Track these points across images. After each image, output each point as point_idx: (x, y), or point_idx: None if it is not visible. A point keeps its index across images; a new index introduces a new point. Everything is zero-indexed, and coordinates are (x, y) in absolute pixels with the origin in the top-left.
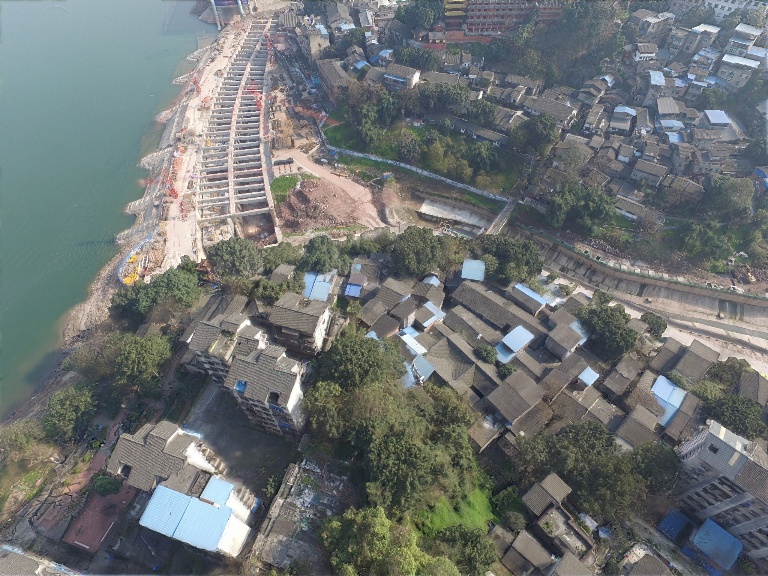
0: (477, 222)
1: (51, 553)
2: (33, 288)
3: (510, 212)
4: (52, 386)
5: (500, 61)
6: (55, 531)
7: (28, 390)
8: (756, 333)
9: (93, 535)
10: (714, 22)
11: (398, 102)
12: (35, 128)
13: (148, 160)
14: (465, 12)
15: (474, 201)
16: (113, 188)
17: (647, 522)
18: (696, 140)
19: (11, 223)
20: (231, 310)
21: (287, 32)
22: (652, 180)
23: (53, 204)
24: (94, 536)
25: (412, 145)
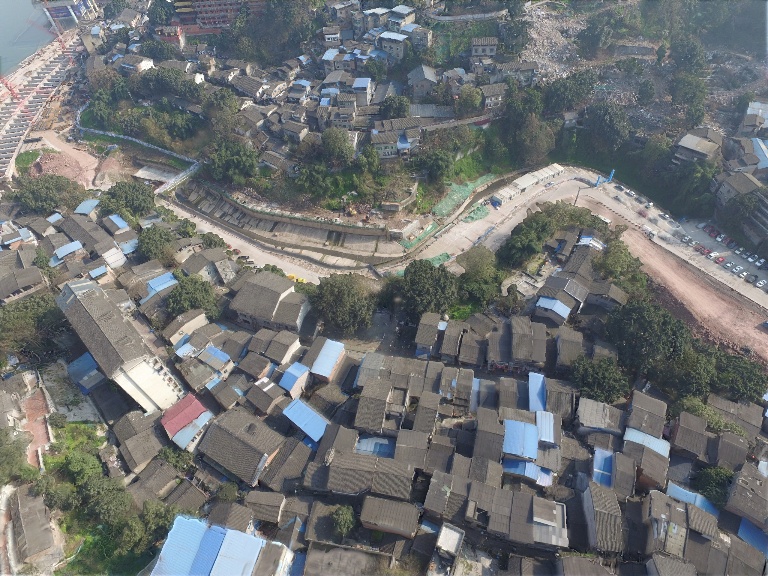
0: None
1: None
2: None
3: (194, 171)
4: None
5: (228, 49)
6: None
7: None
8: (348, 255)
9: None
10: (390, 6)
11: (126, 86)
12: None
13: None
14: (193, 8)
15: (174, 164)
16: None
17: (67, 363)
18: (340, 103)
19: None
20: None
21: None
22: (296, 137)
23: None
24: None
25: (130, 120)
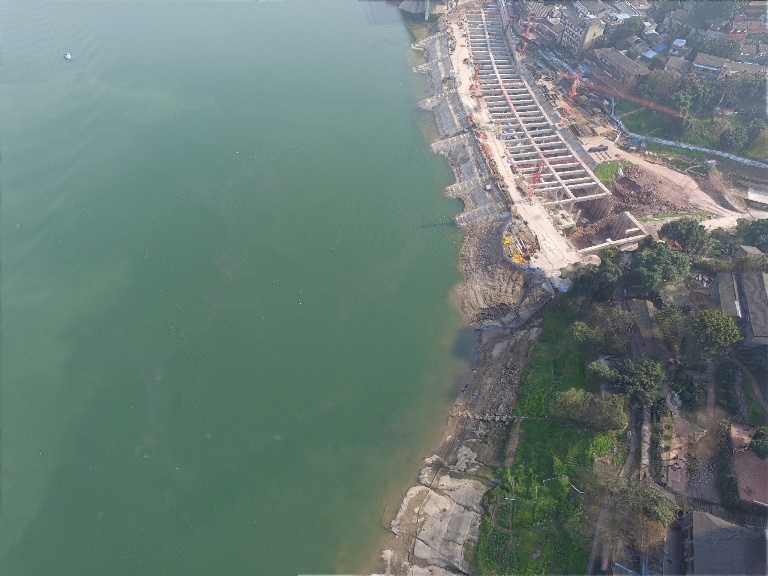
0: None
1: (715, 512)
2: (405, 267)
3: None
4: (486, 361)
5: None
6: (698, 492)
7: (464, 364)
8: None
9: (766, 495)
10: None
11: (715, 91)
12: (307, 114)
13: (443, 146)
14: None
15: None
16: (420, 173)
17: None
18: None
19: (342, 205)
20: (767, 287)
21: (535, 22)
22: None
23: (370, 187)
24: (767, 496)
25: (739, 133)
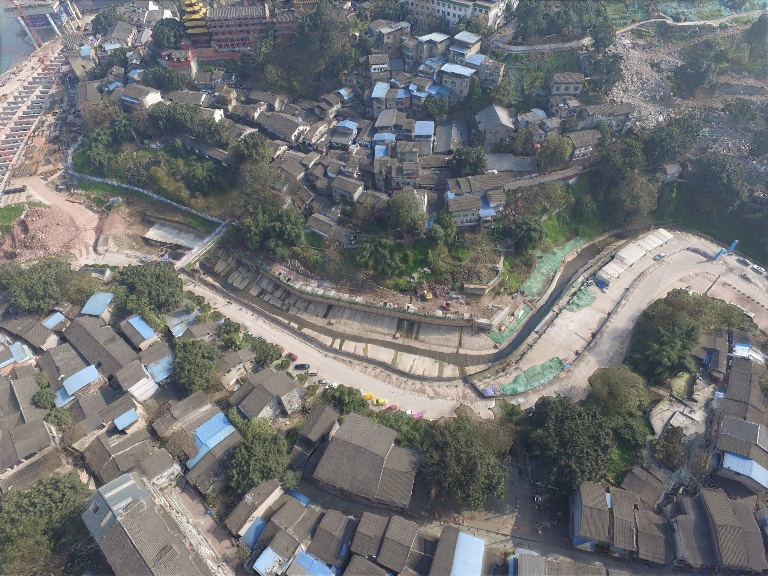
0: None
1: None
2: None
3: (221, 234)
4: None
5: (250, 77)
6: None
7: None
8: (426, 352)
9: None
10: (447, 30)
11: (130, 124)
12: None
13: None
14: (207, 29)
15: (194, 224)
16: None
17: None
18: (400, 153)
19: None
20: None
21: None
22: (349, 197)
23: None
24: None
25: (137, 168)
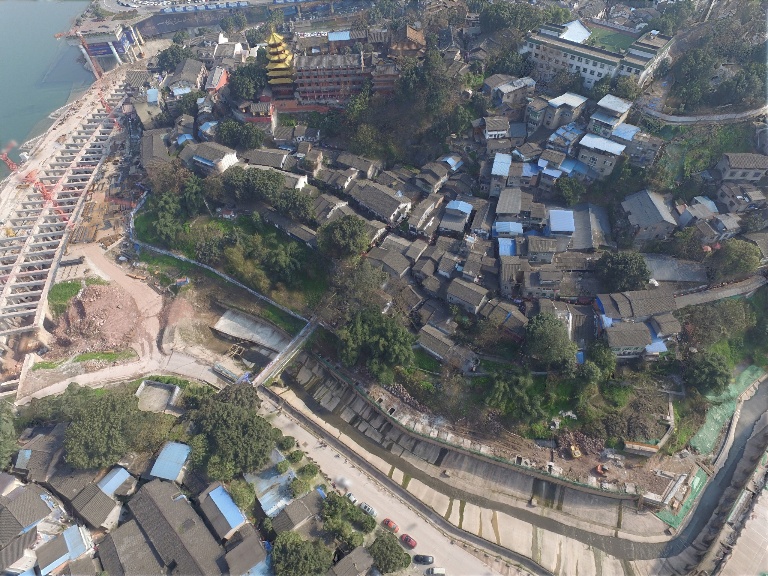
0: (276, 345)
1: None
2: None
3: (306, 338)
4: None
5: (337, 135)
6: None
7: None
8: (574, 532)
9: None
10: (582, 90)
11: (202, 191)
12: None
13: None
14: (292, 79)
15: (273, 318)
16: None
17: None
18: (532, 252)
19: None
20: None
21: None
22: (469, 307)
23: None
24: None
25: (209, 246)
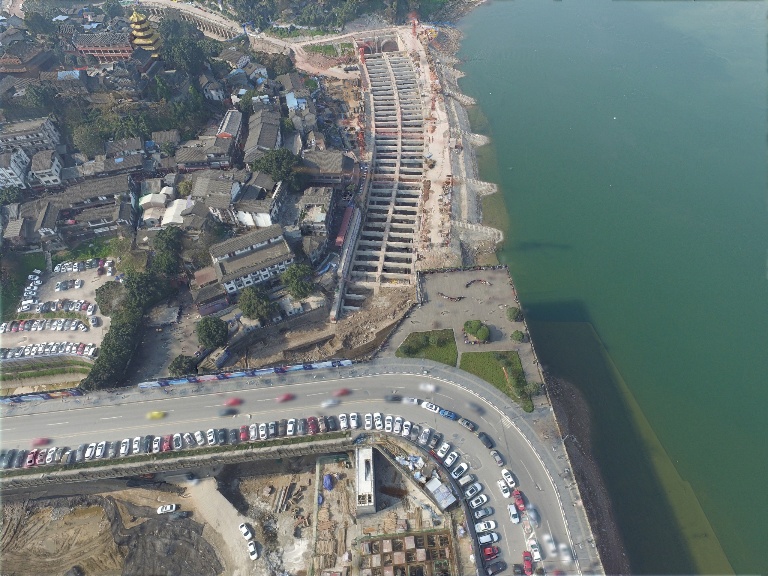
0: None
1: None
2: (491, 44)
3: None
4: (453, 20)
5: None
6: None
7: None
8: None
9: None
10: None
11: None
12: (603, 131)
13: None
14: None
15: None
16: None
17: None
18: None
19: (538, 69)
20: None
21: None
22: None
23: (521, 79)
24: None
25: None
